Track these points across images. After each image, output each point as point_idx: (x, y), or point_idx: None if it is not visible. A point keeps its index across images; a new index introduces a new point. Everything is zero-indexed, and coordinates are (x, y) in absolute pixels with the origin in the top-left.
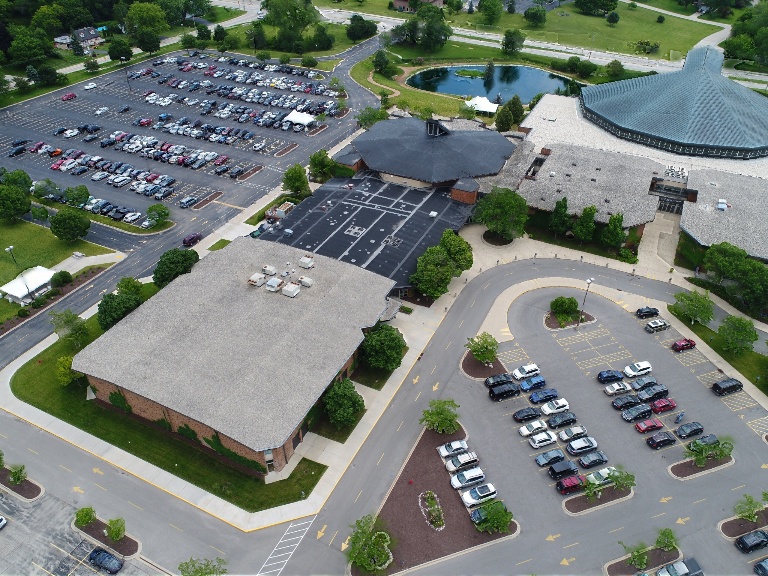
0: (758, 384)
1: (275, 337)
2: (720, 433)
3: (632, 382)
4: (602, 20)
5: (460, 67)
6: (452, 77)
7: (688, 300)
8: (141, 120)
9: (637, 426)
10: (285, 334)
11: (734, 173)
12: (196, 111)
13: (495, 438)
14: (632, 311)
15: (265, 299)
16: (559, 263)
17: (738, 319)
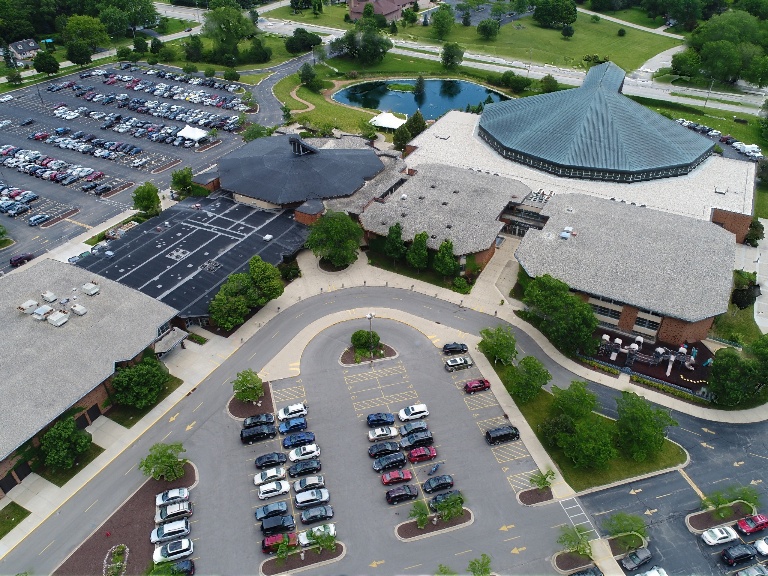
0: (539, 433)
1: (15, 370)
2: (472, 488)
3: (401, 427)
4: (557, 33)
5: (395, 81)
6: (383, 91)
7: (489, 337)
8: (35, 134)
9: (382, 477)
10: (27, 367)
11: (608, 197)
12: (98, 125)
13: (225, 486)
14: (440, 347)
15: (29, 328)
16: (387, 292)
17: (525, 361)
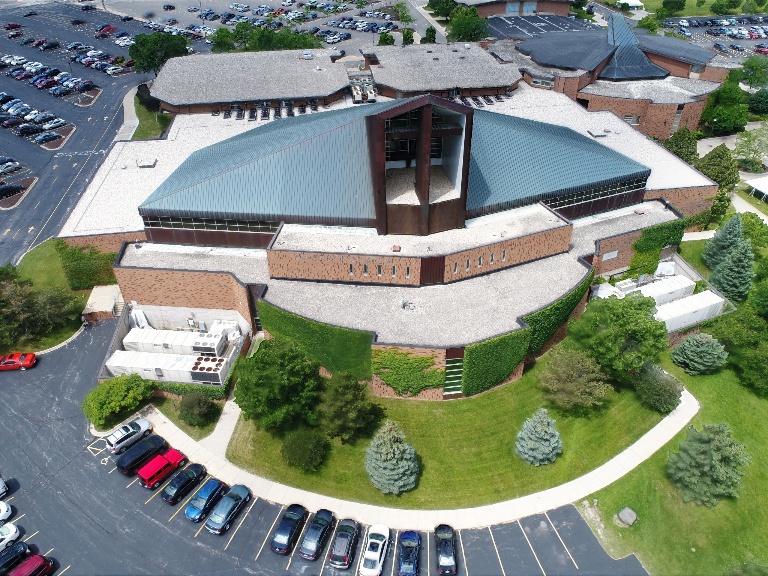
0: None
1: None
2: None
3: None
4: None
5: None
6: None
7: None
8: None
9: None
10: None
11: None
12: None
13: None
14: None
15: None
16: None
17: None
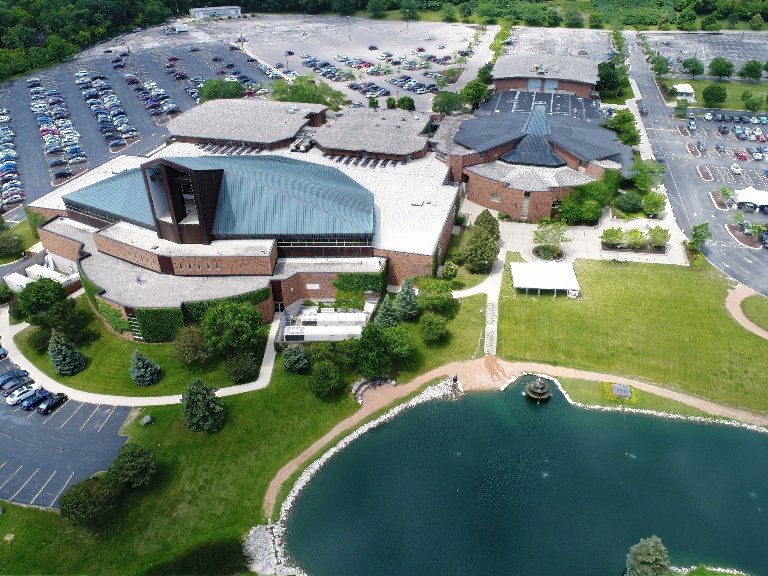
0: None
1: None
2: None
3: None
4: None
5: None
6: None
7: None
8: None
9: None
10: None
11: None
12: None
13: None
14: None
15: None
16: None
17: (326, 84)
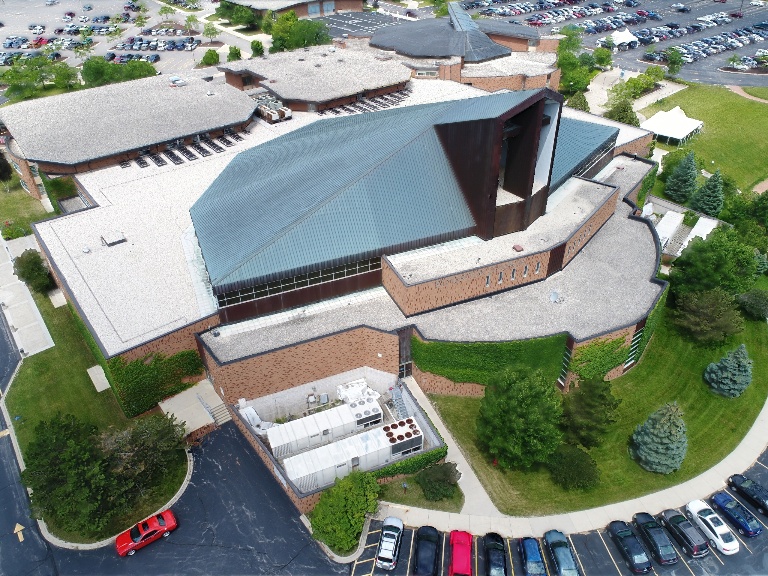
0: None
1: None
2: None
3: None
4: None
5: None
6: None
7: None
8: None
9: None
10: None
11: None
12: None
13: None
14: None
15: None
16: None
17: None
